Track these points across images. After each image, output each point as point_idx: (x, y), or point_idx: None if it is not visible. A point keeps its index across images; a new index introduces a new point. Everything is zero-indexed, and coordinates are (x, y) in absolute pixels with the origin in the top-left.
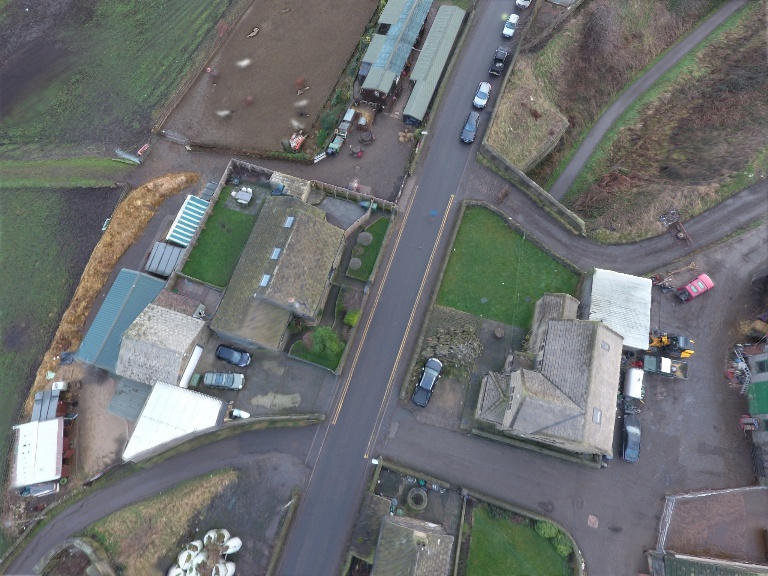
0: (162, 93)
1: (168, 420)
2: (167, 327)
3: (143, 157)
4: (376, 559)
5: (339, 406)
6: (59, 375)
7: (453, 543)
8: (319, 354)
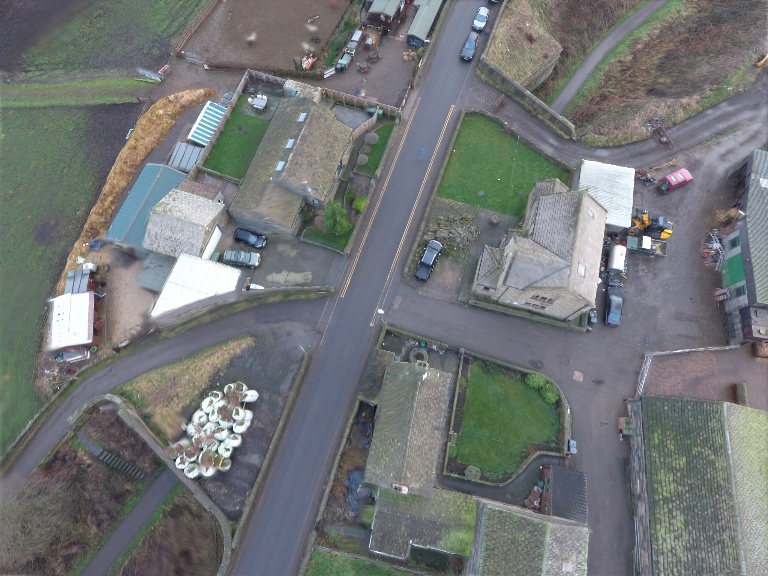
0: (180, 24)
1: (192, 285)
2: (190, 207)
3: (164, 75)
4: (382, 391)
5: (347, 282)
6: (88, 260)
7: (451, 394)
8: (329, 237)
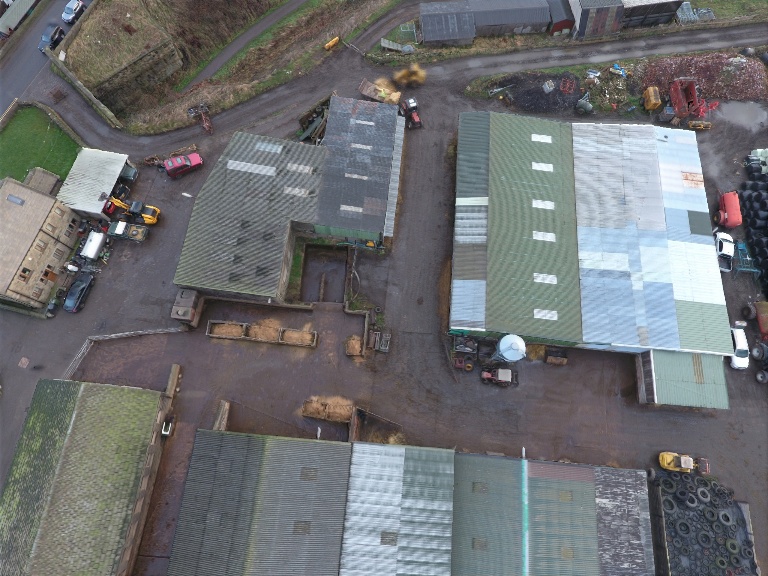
0: None
1: None
2: None
3: None
4: None
5: None
6: None
7: None
8: None
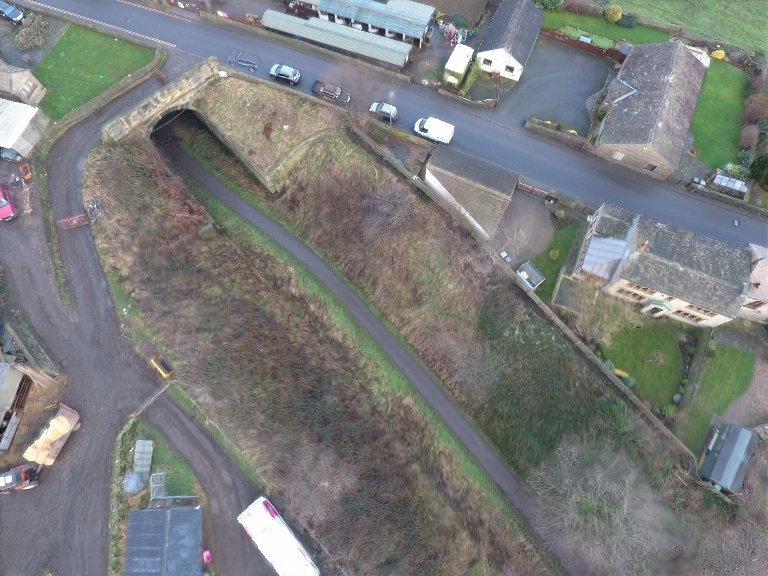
0: None
1: None
2: None
3: None
4: None
5: None
6: None
7: None
8: None
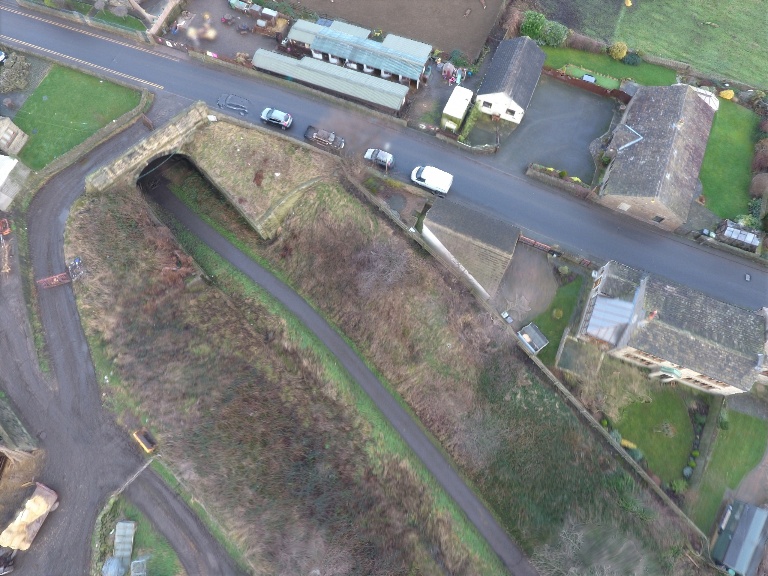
0: None
1: None
2: None
3: None
4: None
5: None
6: None
7: None
8: None
